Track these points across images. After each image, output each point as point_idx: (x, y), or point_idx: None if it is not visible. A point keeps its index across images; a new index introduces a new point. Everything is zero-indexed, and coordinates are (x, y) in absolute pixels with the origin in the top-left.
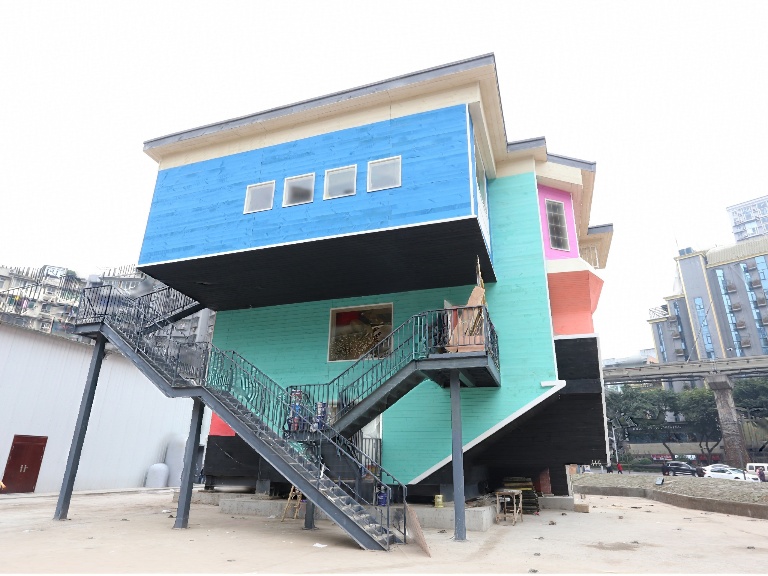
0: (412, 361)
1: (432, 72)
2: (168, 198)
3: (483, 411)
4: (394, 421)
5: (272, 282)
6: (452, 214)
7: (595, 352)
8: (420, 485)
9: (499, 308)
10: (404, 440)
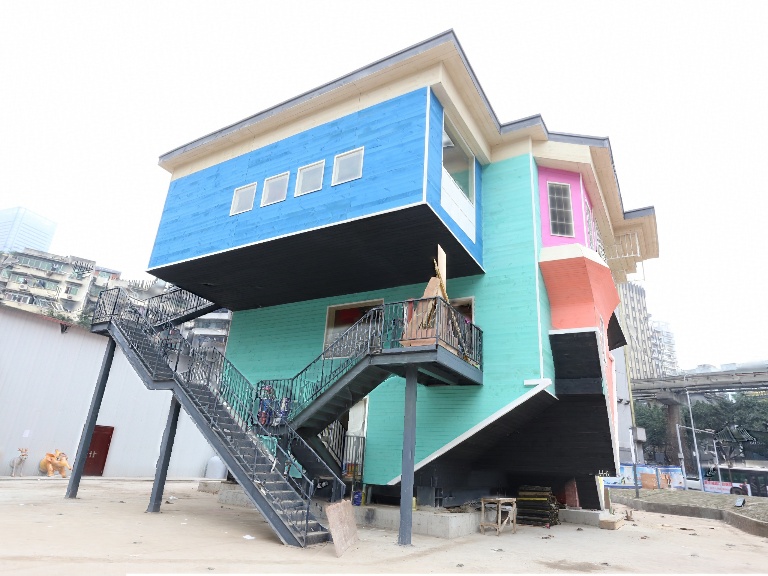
0: (367, 356)
1: (394, 58)
2: (175, 206)
3: (464, 411)
4: (378, 419)
5: (266, 281)
6: (404, 202)
7: (595, 348)
8: (399, 486)
9: (486, 301)
10: (386, 439)
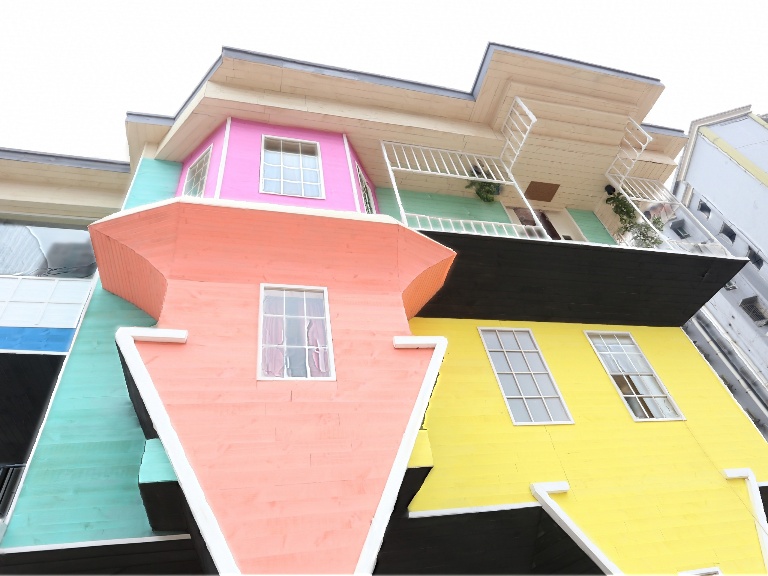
0: None
1: None
2: None
3: None
4: None
5: None
6: None
7: (130, 376)
8: None
9: None
10: None
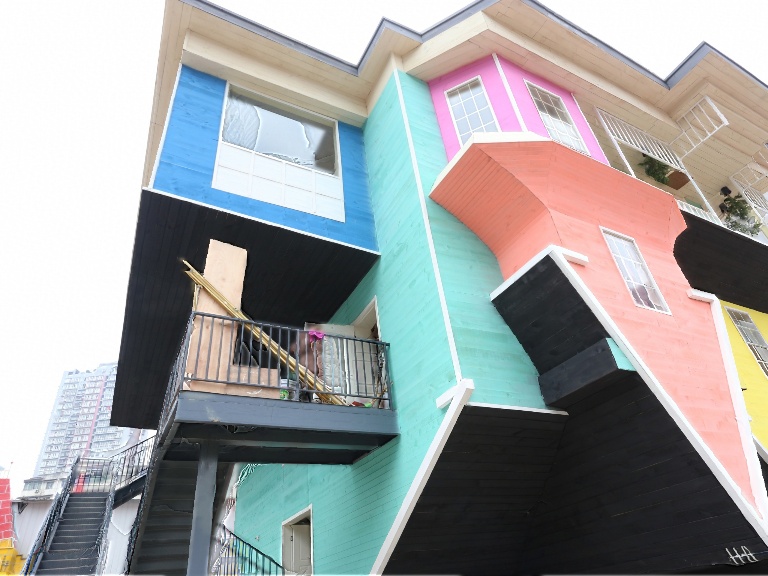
0: None
1: None
2: None
3: (386, 492)
4: (320, 540)
5: None
6: None
7: (565, 285)
8: None
9: (386, 295)
10: (328, 573)
